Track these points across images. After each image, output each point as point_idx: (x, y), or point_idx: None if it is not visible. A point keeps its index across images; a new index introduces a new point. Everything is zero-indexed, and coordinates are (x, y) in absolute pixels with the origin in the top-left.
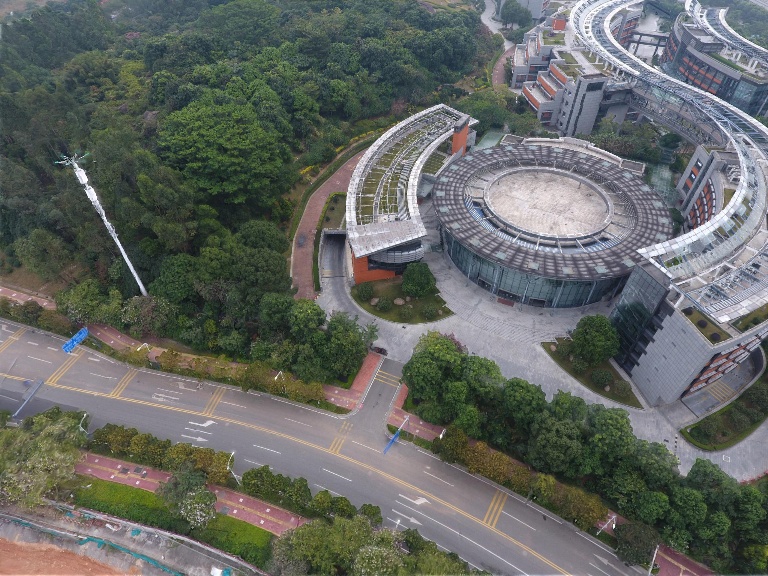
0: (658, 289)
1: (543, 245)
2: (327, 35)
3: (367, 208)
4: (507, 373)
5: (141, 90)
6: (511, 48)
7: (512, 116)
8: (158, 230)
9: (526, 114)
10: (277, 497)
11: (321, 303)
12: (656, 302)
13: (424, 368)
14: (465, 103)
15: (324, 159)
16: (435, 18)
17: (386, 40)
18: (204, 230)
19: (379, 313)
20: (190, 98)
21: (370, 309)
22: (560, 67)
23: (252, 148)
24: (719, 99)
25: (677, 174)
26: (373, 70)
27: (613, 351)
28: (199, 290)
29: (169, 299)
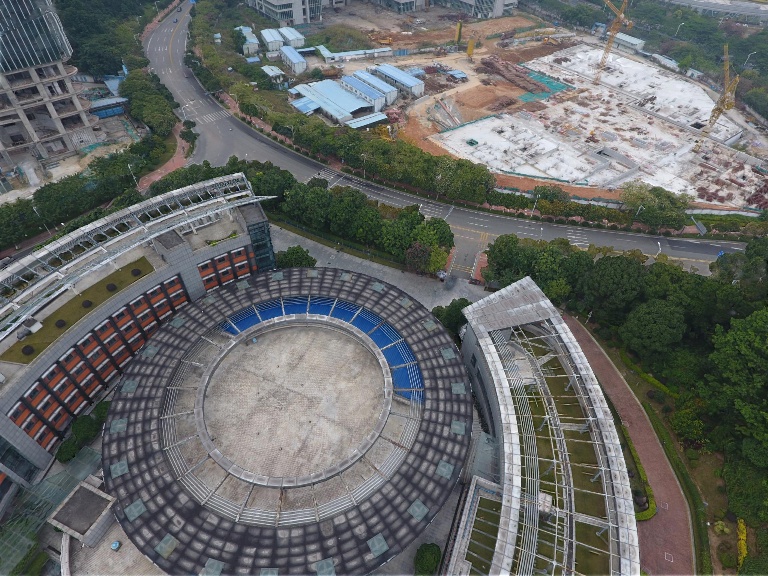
0: None
1: None
2: None
3: (560, 395)
4: (368, 273)
5: None
6: None
7: None
8: None
9: None
10: (507, 213)
11: None
12: None
13: (439, 219)
14: None
15: None
16: None
17: None
18: None
19: None
20: None
21: None
22: None
23: (767, 338)
24: None
25: None
26: None
27: None
28: None
29: None
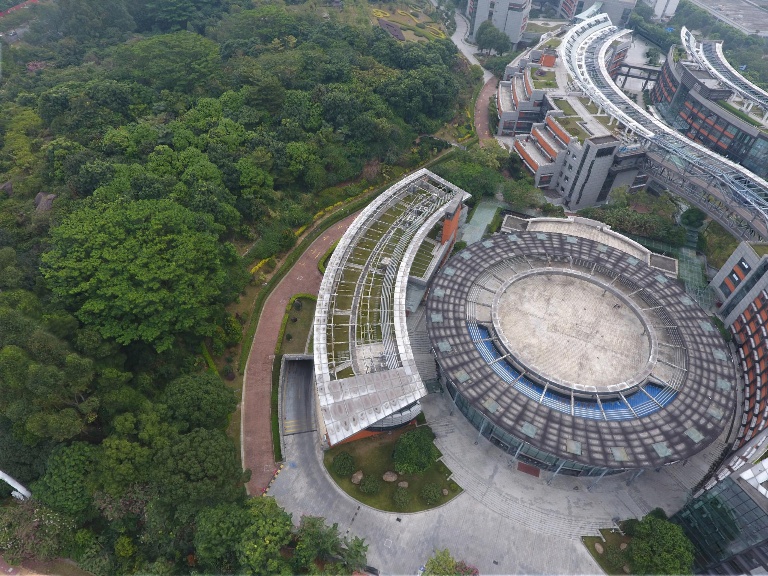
0: (767, 523)
1: (576, 398)
2: (280, 83)
3: (341, 335)
4: None
5: (32, 162)
6: (490, 80)
7: (508, 184)
8: (33, 429)
9: (524, 181)
10: None
11: (284, 482)
12: (762, 537)
13: None
14: (451, 167)
15: (281, 248)
16: (409, 54)
17: (353, 86)
18: (110, 407)
19: (364, 496)
20: (97, 181)
21: (351, 490)
22: (559, 121)
23: (180, 274)
24: (753, 174)
25: (701, 256)
26: (339, 124)
27: (688, 575)
28: (102, 508)
29: (60, 510)
